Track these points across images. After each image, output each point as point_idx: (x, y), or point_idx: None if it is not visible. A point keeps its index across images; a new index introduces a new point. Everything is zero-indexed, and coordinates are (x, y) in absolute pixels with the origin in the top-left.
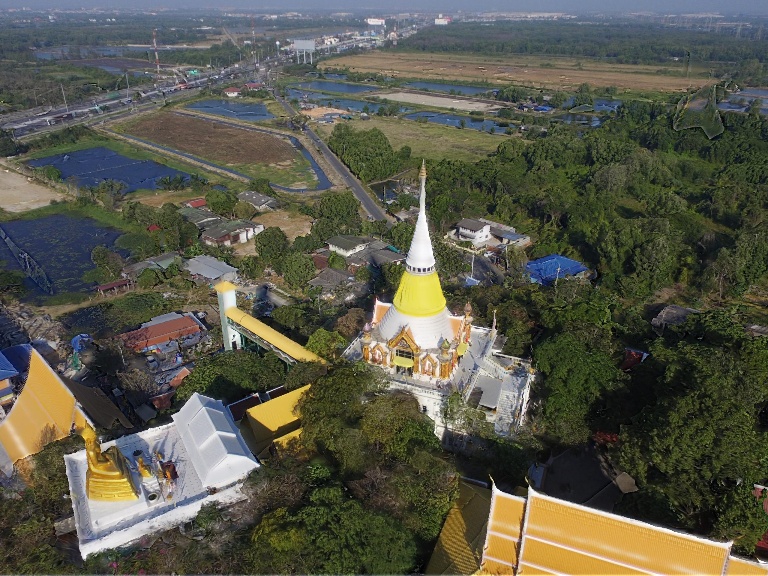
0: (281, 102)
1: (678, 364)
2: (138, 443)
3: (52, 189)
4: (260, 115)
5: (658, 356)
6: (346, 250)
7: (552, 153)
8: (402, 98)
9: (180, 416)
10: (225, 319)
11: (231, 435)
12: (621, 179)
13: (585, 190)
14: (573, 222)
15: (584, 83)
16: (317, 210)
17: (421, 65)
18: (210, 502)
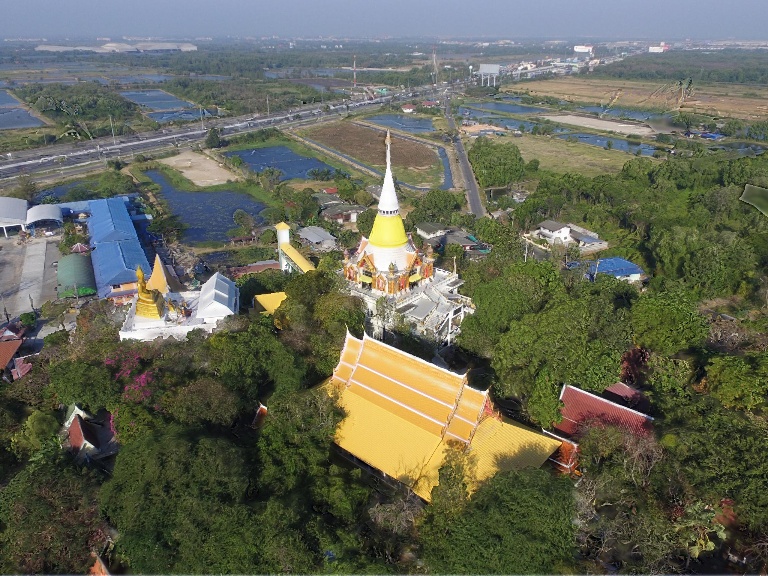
0: (448, 118)
1: None
2: (179, 298)
3: (233, 173)
4: (423, 128)
5: (557, 298)
6: (427, 233)
7: (676, 173)
8: (567, 120)
9: (205, 285)
10: (280, 251)
11: (225, 295)
12: (733, 200)
13: None
14: (654, 233)
15: None
16: (421, 202)
17: (608, 91)
18: (199, 328)
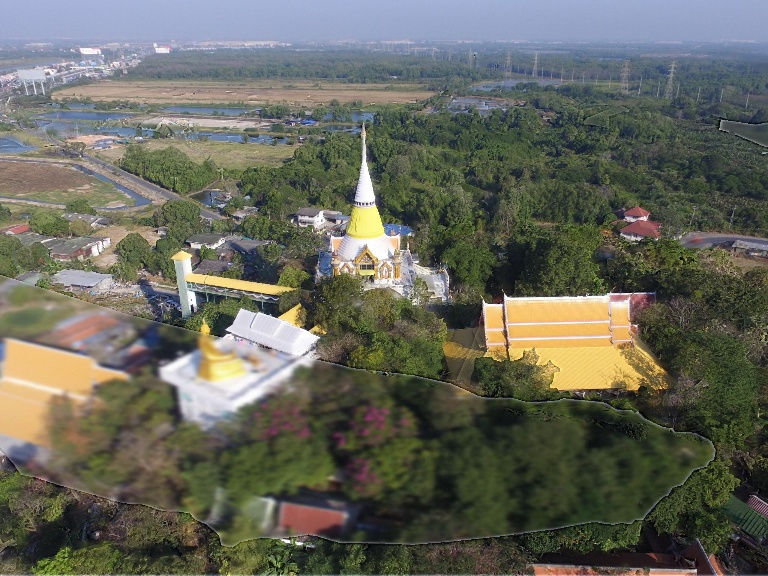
0: None
1: None
2: None
3: None
4: (19, 147)
5: (520, 241)
6: (211, 244)
7: (343, 153)
8: None
9: (236, 326)
10: (185, 285)
11: (290, 324)
12: (407, 166)
13: (381, 178)
14: (387, 200)
15: (334, 99)
16: (160, 218)
17: (166, 92)
18: None
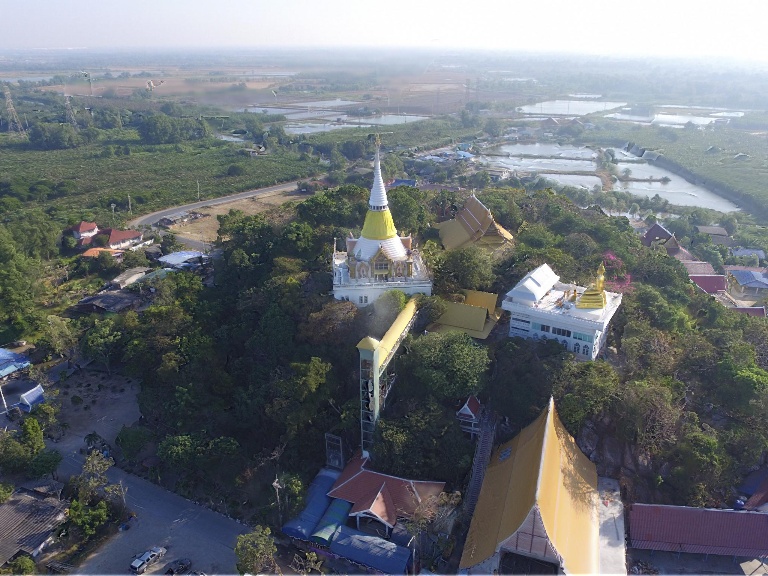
0: None
1: (355, 209)
2: None
3: None
4: None
5: (348, 213)
6: None
7: None
8: None
9: None
10: None
11: None
12: None
13: None
14: None
15: None
16: None
17: None
18: None
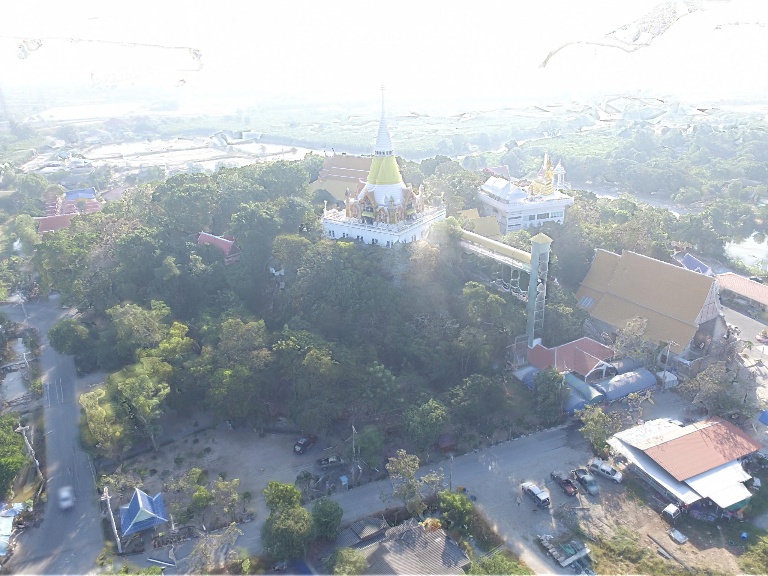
0: None
1: None
2: None
3: None
4: None
5: None
6: None
7: None
8: None
9: None
10: None
11: None
12: None
13: None
14: None
15: None
16: None
17: None
18: None
